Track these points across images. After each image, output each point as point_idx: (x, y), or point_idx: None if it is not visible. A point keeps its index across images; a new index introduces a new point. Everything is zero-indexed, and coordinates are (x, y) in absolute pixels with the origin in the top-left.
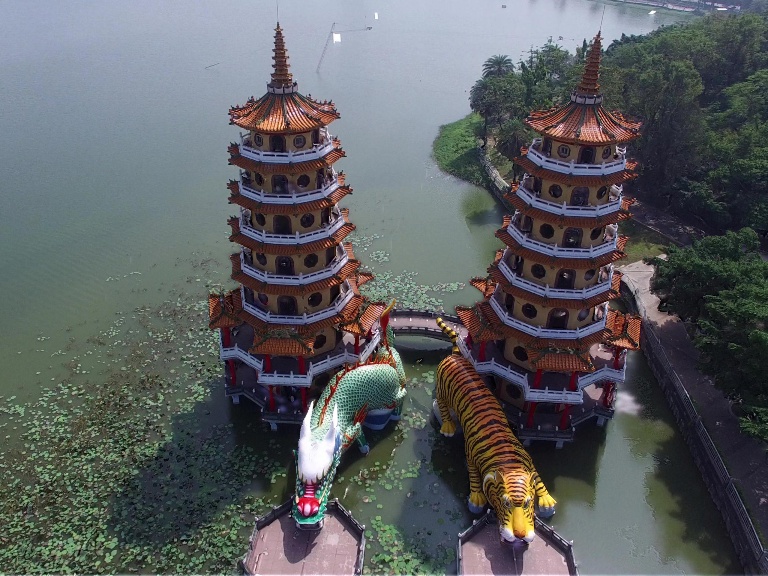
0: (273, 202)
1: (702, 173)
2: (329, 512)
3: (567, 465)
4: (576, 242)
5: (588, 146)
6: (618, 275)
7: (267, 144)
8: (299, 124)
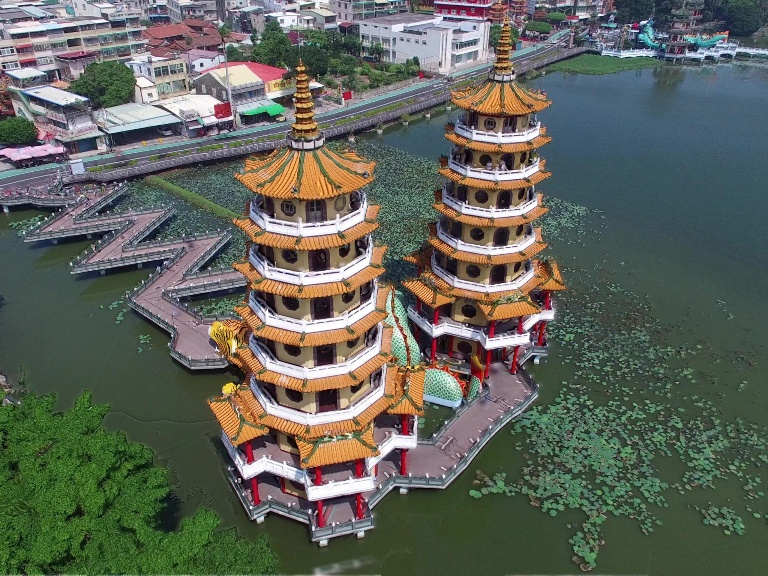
0: None
1: None
2: None
3: None
4: None
5: None
6: (259, 371)
7: None
8: None
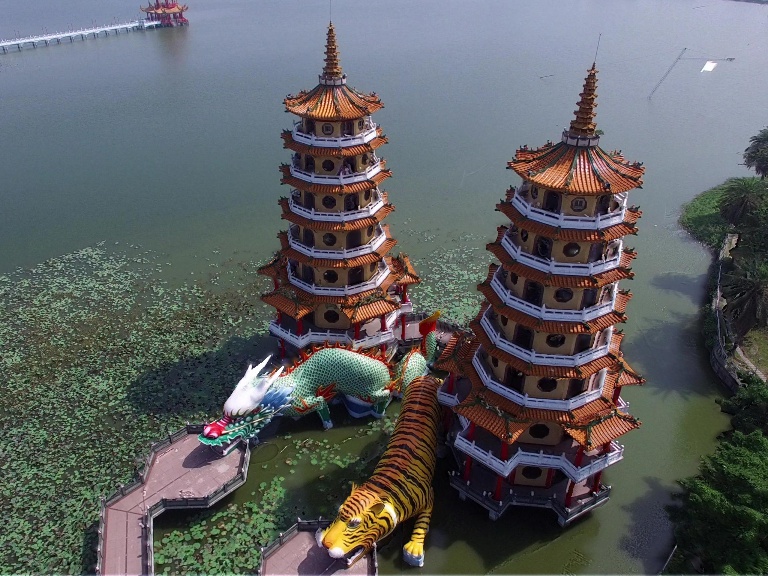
0: (299, 177)
1: None
2: (241, 449)
3: (496, 541)
4: (538, 297)
5: (552, 191)
6: (610, 359)
7: (305, 126)
8: (322, 112)
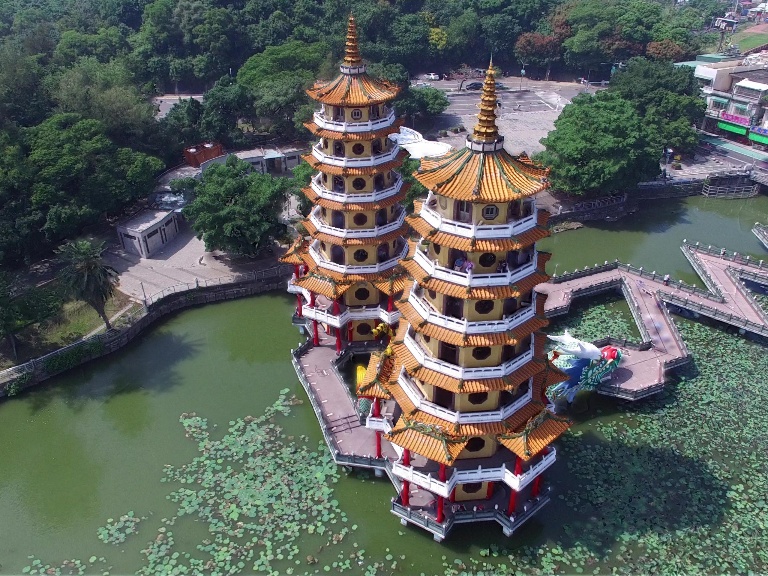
0: None
1: (3, 214)
2: None
3: None
4: None
5: None
6: None
7: None
8: None
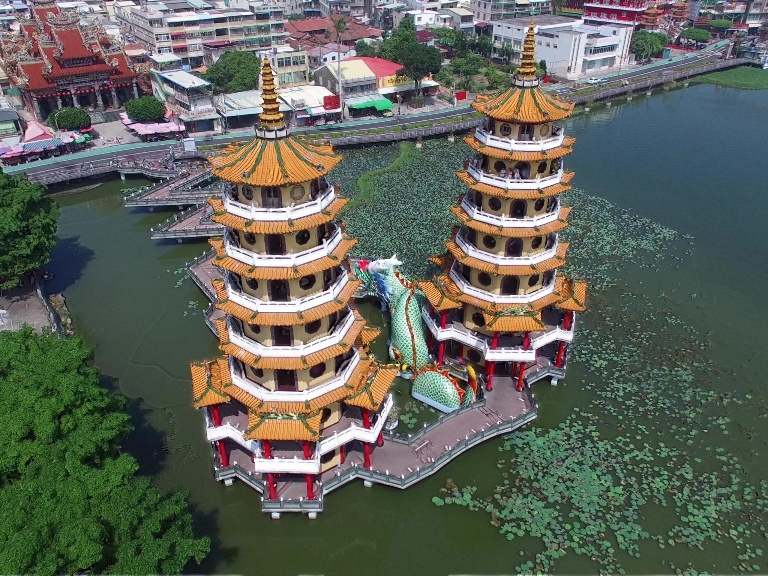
0: None
1: None
2: None
3: None
4: None
5: None
6: None
7: None
8: None
